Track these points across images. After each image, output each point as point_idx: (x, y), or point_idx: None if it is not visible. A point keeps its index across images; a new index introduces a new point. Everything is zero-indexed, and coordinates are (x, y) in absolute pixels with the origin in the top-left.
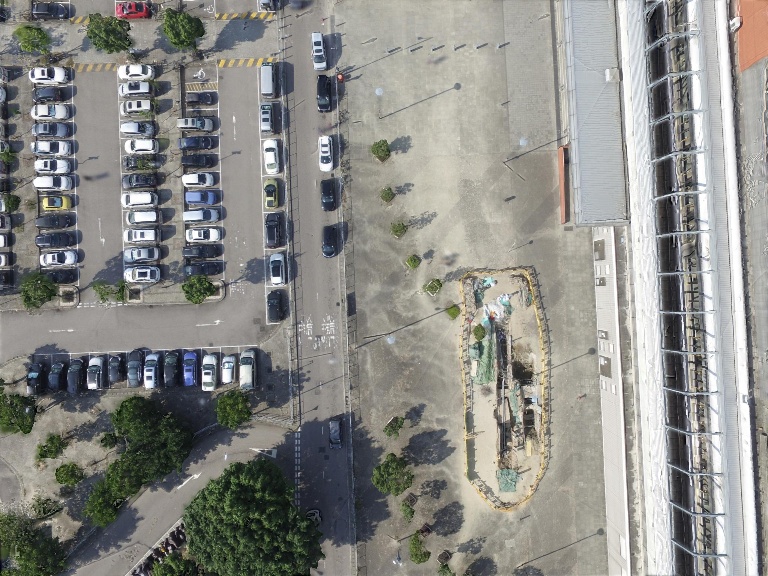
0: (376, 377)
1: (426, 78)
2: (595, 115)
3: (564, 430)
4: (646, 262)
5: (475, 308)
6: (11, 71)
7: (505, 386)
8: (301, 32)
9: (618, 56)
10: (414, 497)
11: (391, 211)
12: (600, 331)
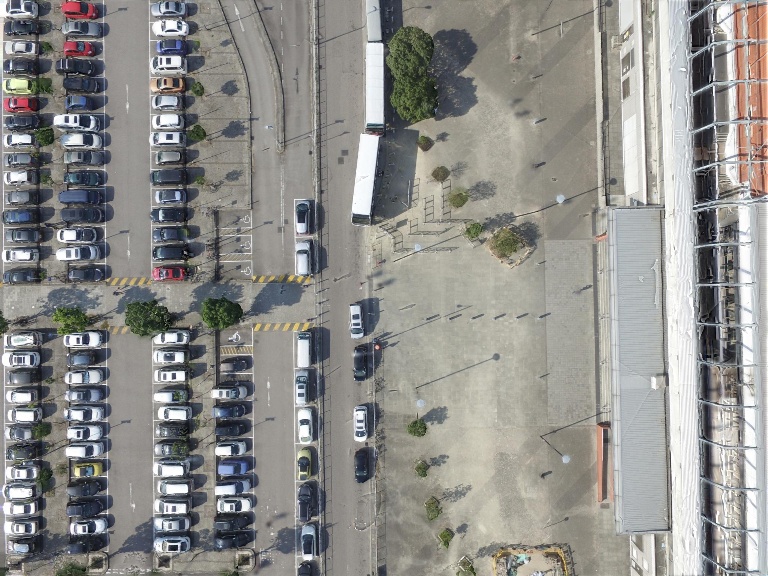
0: None
1: (464, 347)
2: (639, 421)
3: None
4: None
5: None
6: (46, 333)
7: None
8: (338, 296)
9: (664, 356)
10: None
11: (425, 483)
12: None
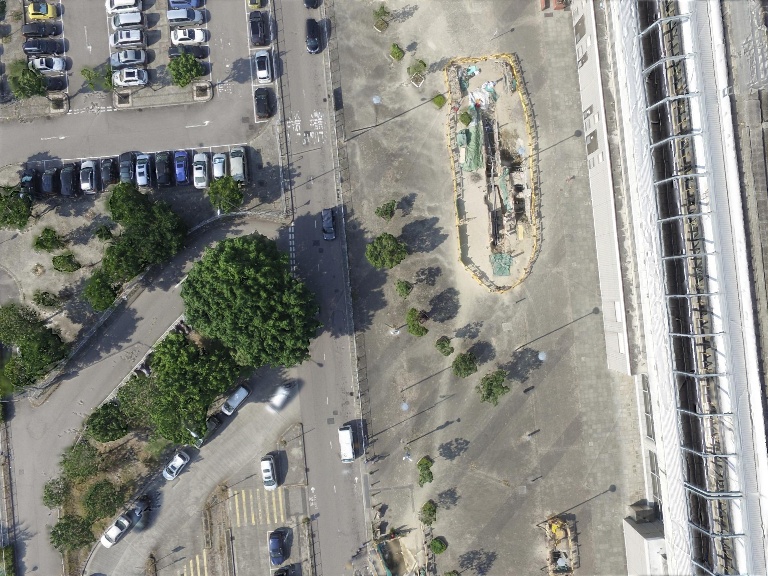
0: (366, 169)
1: None
2: None
3: (555, 212)
4: (625, 18)
5: (460, 94)
6: None
7: (494, 174)
8: None
9: None
10: (409, 285)
11: (373, 6)
12: (585, 111)
